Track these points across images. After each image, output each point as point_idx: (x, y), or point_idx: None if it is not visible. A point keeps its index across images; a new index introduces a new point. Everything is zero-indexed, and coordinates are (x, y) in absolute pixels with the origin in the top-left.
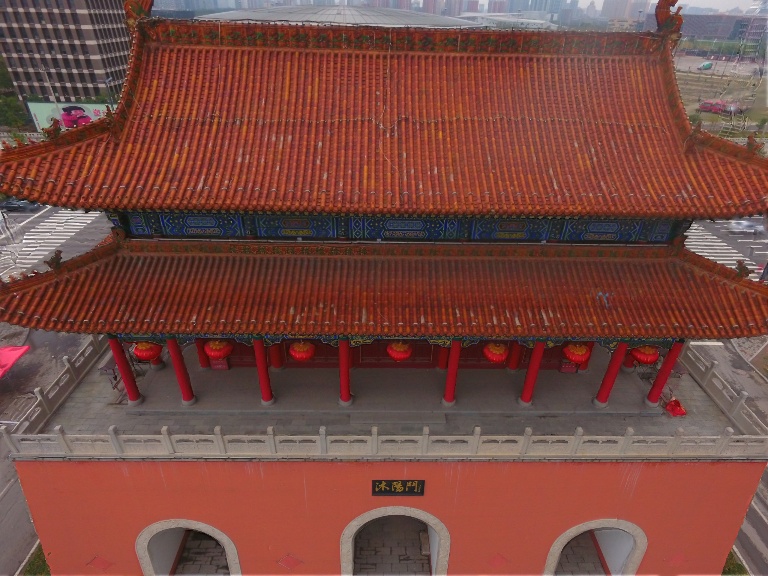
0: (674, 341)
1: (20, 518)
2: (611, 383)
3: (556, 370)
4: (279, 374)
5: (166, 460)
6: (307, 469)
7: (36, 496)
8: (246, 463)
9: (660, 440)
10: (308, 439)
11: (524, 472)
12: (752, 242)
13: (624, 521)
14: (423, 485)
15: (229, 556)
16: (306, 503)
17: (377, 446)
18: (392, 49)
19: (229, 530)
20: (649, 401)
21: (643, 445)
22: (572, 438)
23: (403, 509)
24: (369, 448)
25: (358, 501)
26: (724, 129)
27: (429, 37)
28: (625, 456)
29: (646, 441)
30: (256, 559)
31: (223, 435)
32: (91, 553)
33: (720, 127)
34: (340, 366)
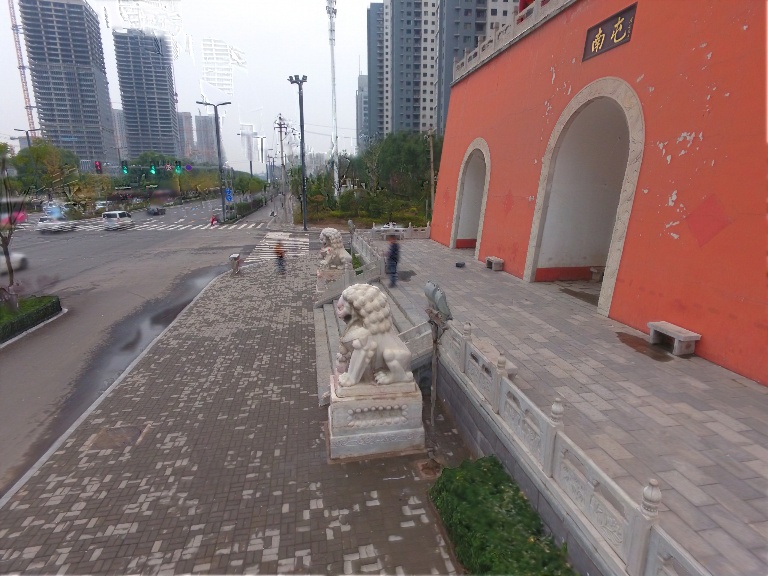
0: None
1: None
2: None
3: None
4: None
5: None
6: None
7: None
8: None
9: None
10: None
11: None
12: (153, 222)
13: None
14: None
15: None
16: None
17: None
18: None
19: None
20: None
21: None
22: None
23: None
24: None
25: None
26: (154, 59)
27: None
28: None
29: None
30: None
31: None
32: None
33: (148, 57)
34: None
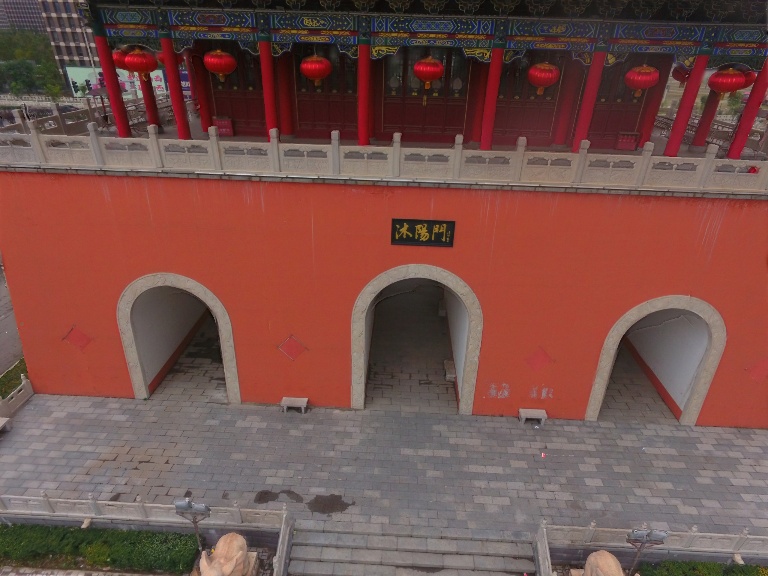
0: (766, 55)
1: (5, 343)
2: (684, 125)
3: (611, 149)
4: (289, 141)
5: (153, 175)
6: (315, 198)
7: (7, 231)
8: (245, 185)
9: (751, 165)
10: (318, 149)
11: (577, 213)
12: None
13: (699, 300)
14: (453, 230)
15: (222, 334)
16: (313, 254)
17: (399, 164)
18: None
19: (223, 295)
20: (729, 158)
21: (729, 174)
22: (639, 157)
23: (428, 269)
24: (390, 168)
25: (374, 254)
26: None
27: None
28: (705, 189)
29: (733, 167)
30: (253, 343)
31: (219, 140)
32: (68, 323)
33: None
34: (359, 90)
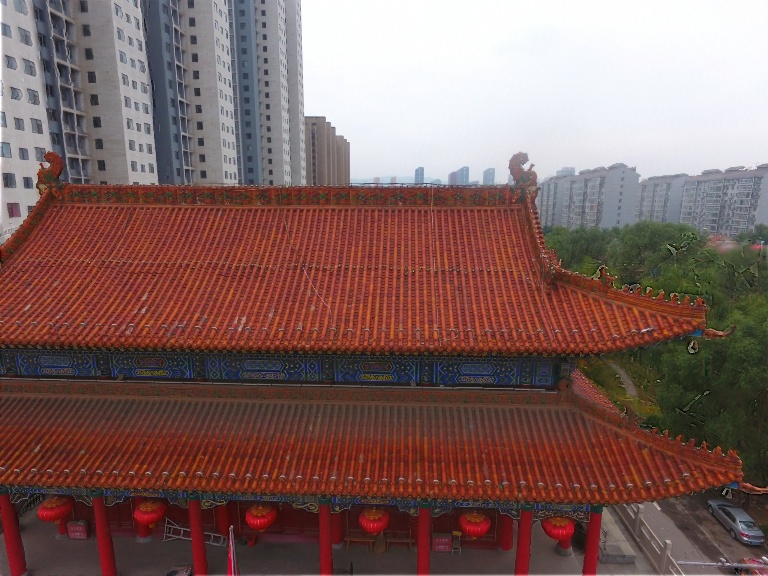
0: None
1: None
2: None
3: None
4: None
5: None
6: None
7: None
8: None
9: None
10: None
11: None
12: None
13: None
14: None
15: None
16: None
17: None
18: (297, 204)
19: None
20: None
21: None
22: None
23: None
24: None
25: None
26: None
27: (264, 194)
28: None
29: None
30: None
31: None
32: None
33: None
34: None
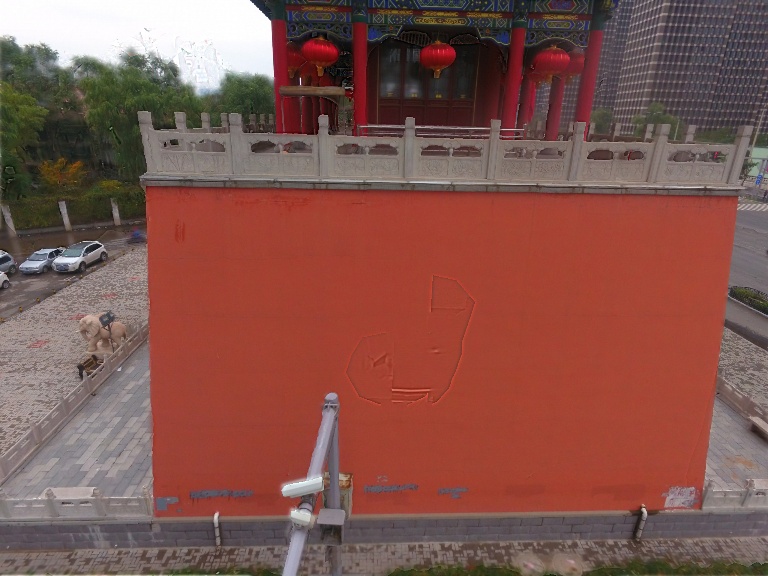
0: None
1: None
2: None
3: None
4: None
5: None
6: None
7: None
8: None
9: None
10: None
11: None
12: None
13: None
14: None
15: None
16: None
17: None
18: None
19: None
20: None
21: None
22: None
23: None
24: None
25: None
26: None
27: None
28: None
29: None
30: None
31: None
32: None
33: None
34: None
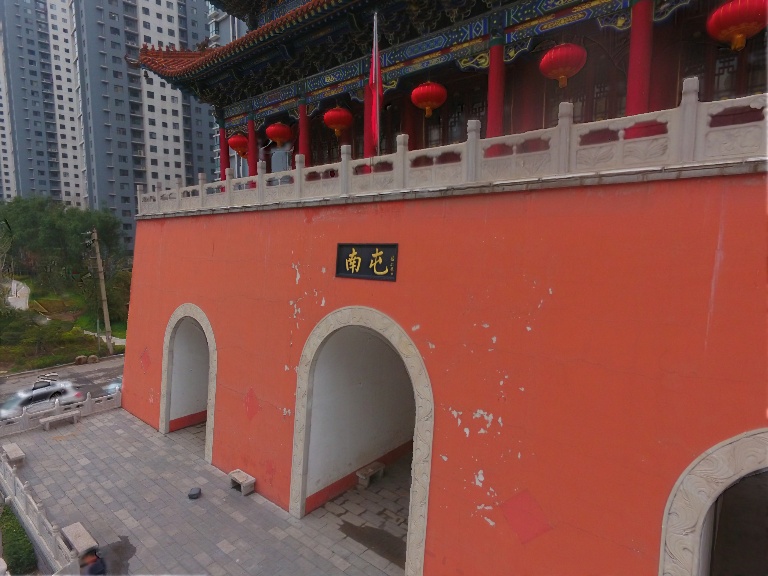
0: None
1: None
2: None
3: None
4: None
5: None
6: None
7: None
8: None
9: None
10: None
11: None
12: None
13: None
14: None
15: None
16: None
17: None
18: None
19: None
20: None
21: None
22: None
23: None
24: None
25: None
26: None
27: None
28: None
29: None
30: None
31: None
32: None
33: None
34: None
